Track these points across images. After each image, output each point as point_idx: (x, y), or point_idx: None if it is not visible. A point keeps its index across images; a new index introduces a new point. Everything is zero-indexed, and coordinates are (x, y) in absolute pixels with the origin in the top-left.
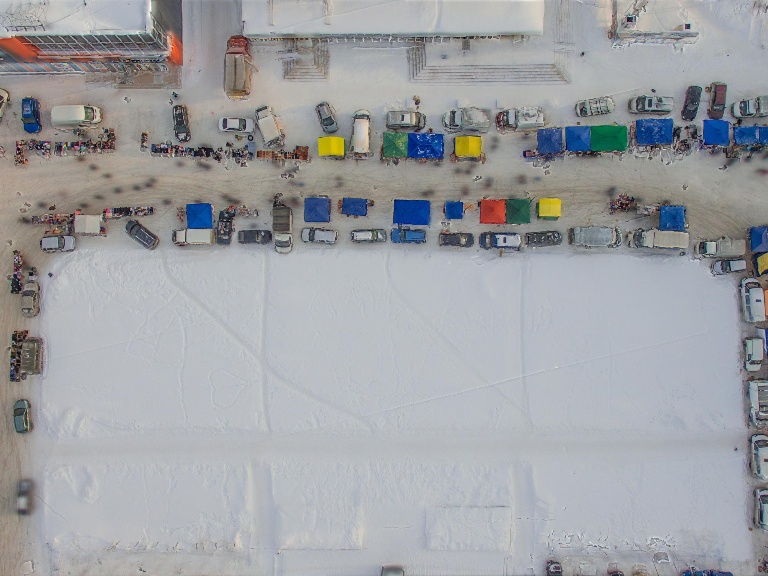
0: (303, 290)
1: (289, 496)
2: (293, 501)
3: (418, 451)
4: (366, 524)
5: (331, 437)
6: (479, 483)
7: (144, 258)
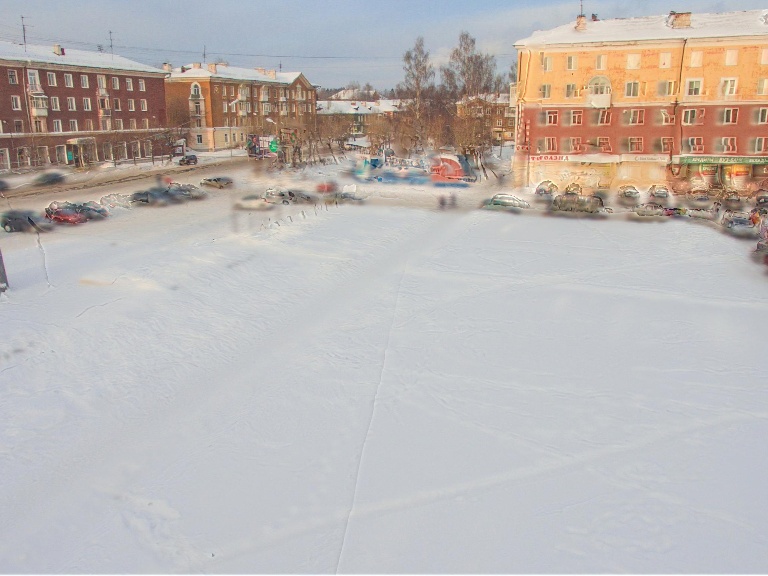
0: (726, 317)
1: (294, 258)
2: (283, 257)
3: (237, 376)
4: (159, 285)
5: (369, 301)
6: (5, 432)
7: (738, 248)
